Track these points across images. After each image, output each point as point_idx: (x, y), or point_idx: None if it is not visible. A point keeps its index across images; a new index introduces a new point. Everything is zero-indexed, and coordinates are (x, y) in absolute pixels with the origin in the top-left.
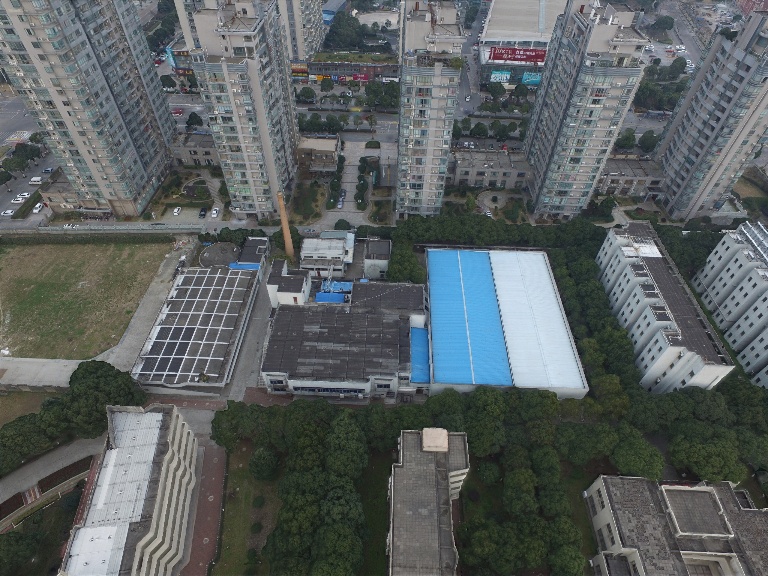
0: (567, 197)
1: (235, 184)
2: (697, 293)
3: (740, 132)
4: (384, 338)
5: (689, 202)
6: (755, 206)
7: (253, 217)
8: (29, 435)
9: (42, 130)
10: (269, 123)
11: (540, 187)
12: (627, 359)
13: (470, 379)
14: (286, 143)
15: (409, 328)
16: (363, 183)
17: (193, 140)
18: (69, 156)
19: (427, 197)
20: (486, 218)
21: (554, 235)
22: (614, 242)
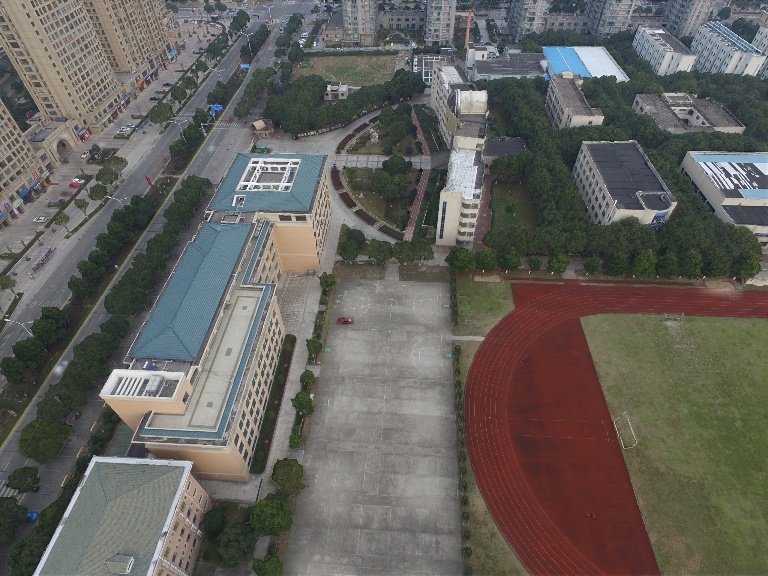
0: (614, 26)
1: (432, 21)
2: None
3: None
4: None
5: (683, 30)
6: None
7: None
8: (390, 86)
9: None
10: None
11: (598, 23)
12: None
13: None
14: None
15: (541, 65)
16: None
17: (389, 14)
18: (350, 4)
19: (536, 27)
20: (571, 31)
21: (608, 40)
22: (641, 30)
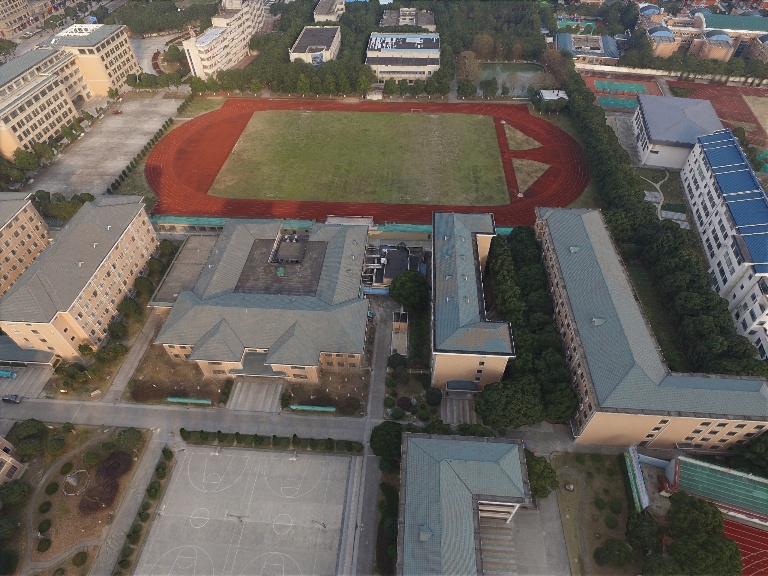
0: None
1: None
2: None
3: None
4: None
5: None
6: None
7: None
8: (216, 6)
9: None
10: None
11: None
12: None
13: None
14: None
15: None
16: None
17: None
18: None
19: None
20: None
21: None
22: None
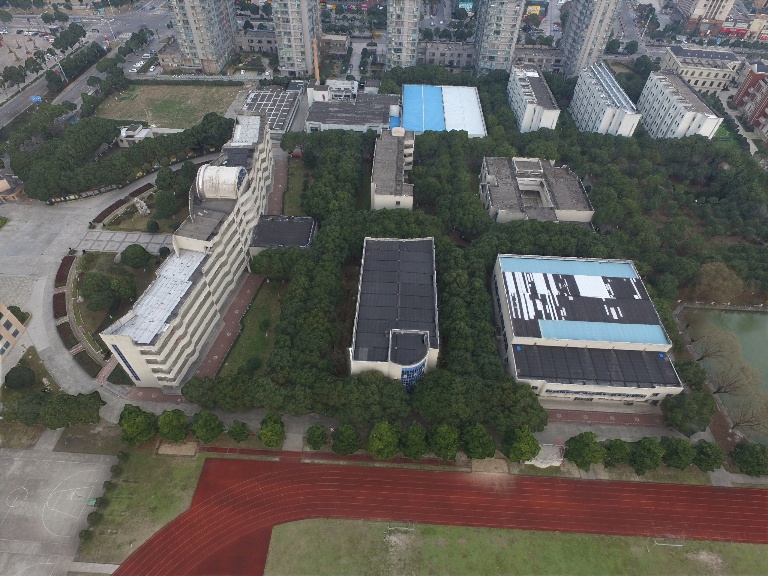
0: (495, 62)
1: (283, 48)
2: (570, 114)
3: (597, 13)
4: (375, 113)
5: (575, 68)
6: (623, 76)
7: (292, 76)
8: (187, 136)
9: (169, 5)
10: (307, 3)
11: None
12: (510, 120)
13: (422, 130)
14: (315, 28)
15: (389, 111)
16: (364, 61)
17: (250, 34)
18: (182, 25)
19: (405, 59)
20: (440, 66)
21: (483, 79)
22: (513, 71)
